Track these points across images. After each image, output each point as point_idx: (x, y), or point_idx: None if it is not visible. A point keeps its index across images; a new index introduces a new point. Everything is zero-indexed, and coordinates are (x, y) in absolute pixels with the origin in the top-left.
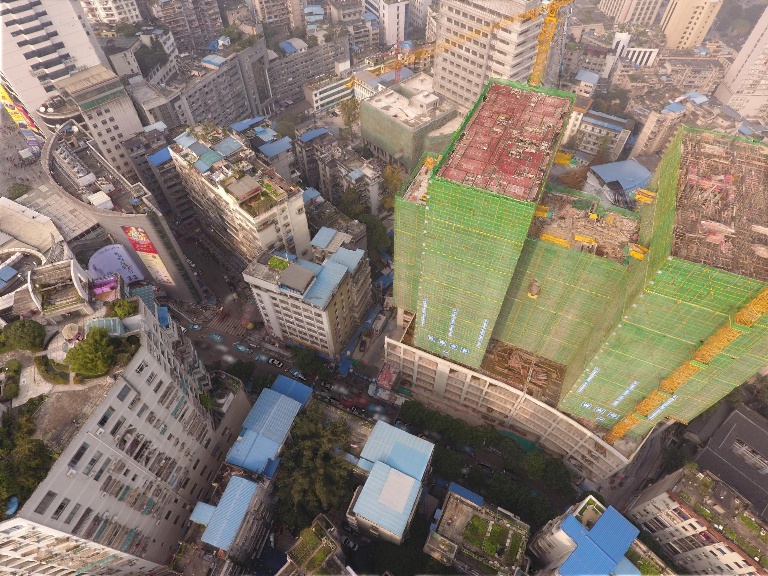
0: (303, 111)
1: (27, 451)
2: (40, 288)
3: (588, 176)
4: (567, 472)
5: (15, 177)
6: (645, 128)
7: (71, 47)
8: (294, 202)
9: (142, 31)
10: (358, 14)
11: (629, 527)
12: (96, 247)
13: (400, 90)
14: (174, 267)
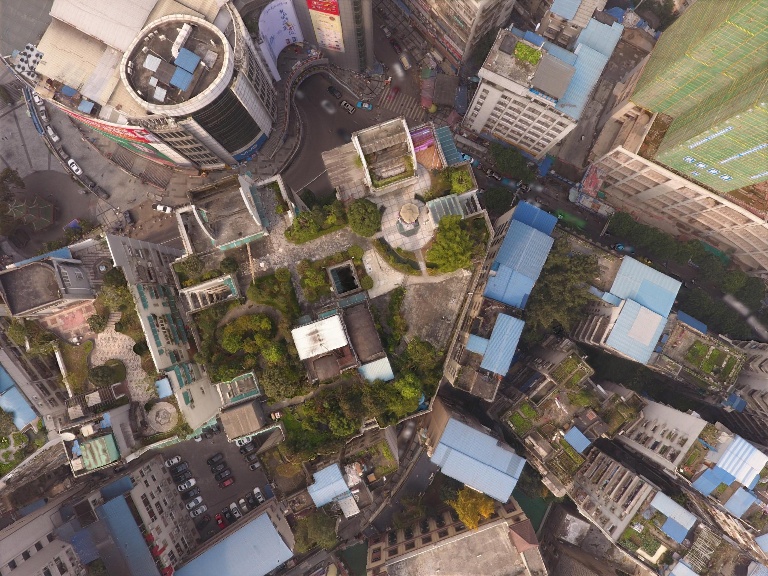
0: None
1: (430, 359)
2: (364, 156)
3: None
4: (764, 291)
5: None
6: None
7: None
8: None
9: None
10: None
11: None
12: (261, 4)
13: None
14: (353, 32)
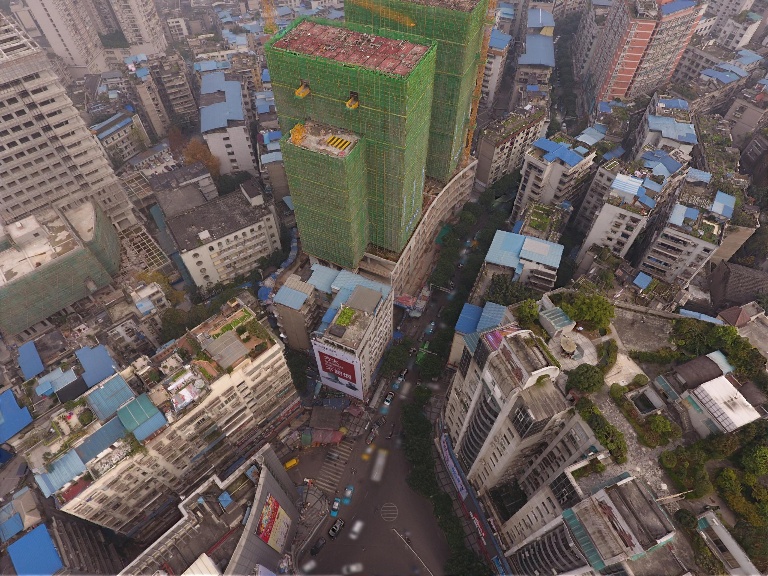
0: None
1: (692, 320)
2: None
3: (206, 139)
4: None
5: None
6: (145, 102)
7: None
8: None
9: None
10: None
11: (542, 140)
12: None
13: None
14: (286, 497)
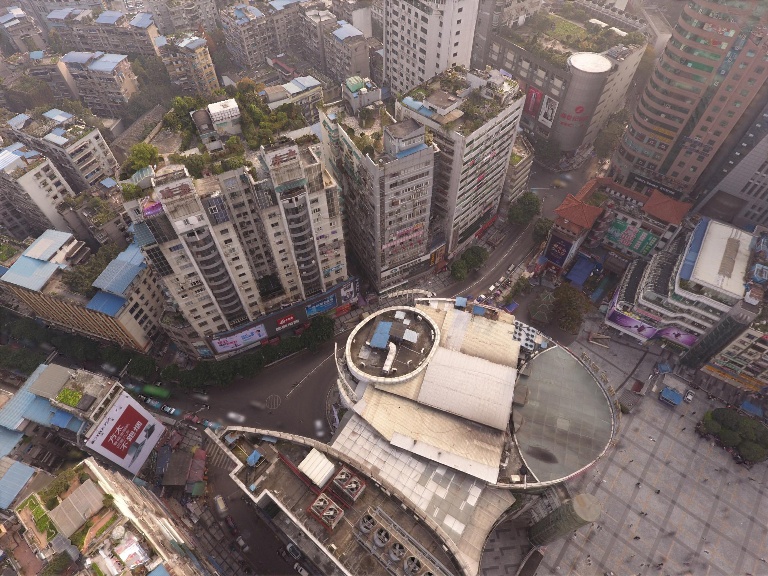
0: None
1: (165, 115)
2: None
3: None
4: None
5: None
6: None
7: None
8: None
9: None
10: None
11: None
12: None
13: None
14: None
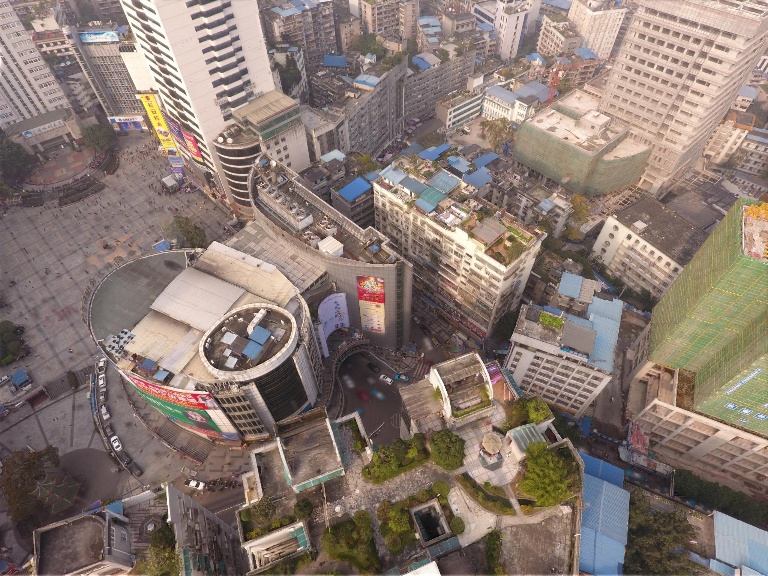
0: (436, 130)
1: None
2: None
3: None
4: None
5: (163, 207)
6: None
7: (253, 73)
8: (536, 246)
9: (276, 49)
10: (471, 25)
11: None
12: (321, 297)
13: (558, 109)
14: (394, 316)
